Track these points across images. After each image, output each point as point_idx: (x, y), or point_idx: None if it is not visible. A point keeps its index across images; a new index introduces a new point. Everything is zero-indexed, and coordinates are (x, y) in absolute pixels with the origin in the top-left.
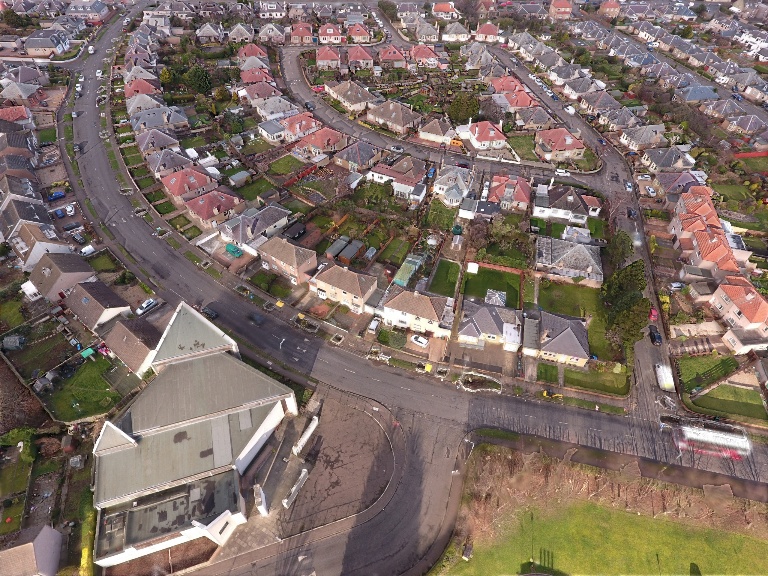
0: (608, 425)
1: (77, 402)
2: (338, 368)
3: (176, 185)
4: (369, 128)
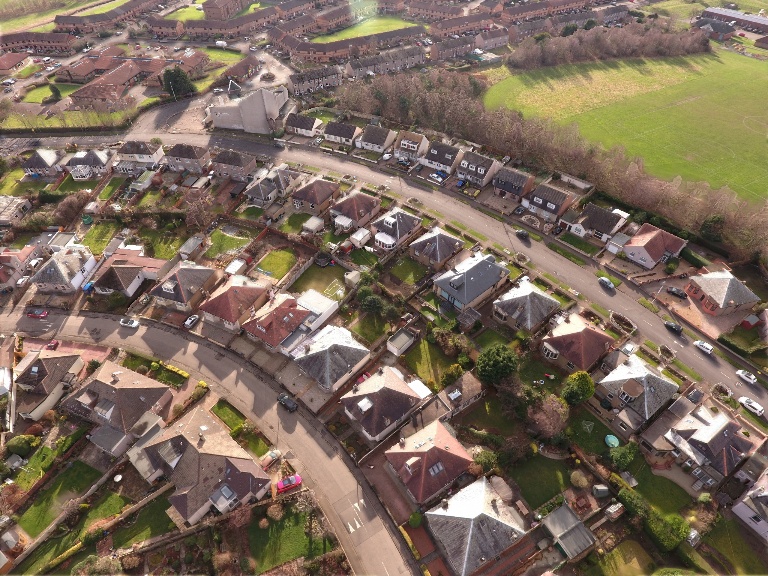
0: (48, 143)
1: (322, 116)
2: (196, 140)
3: (358, 191)
4: None
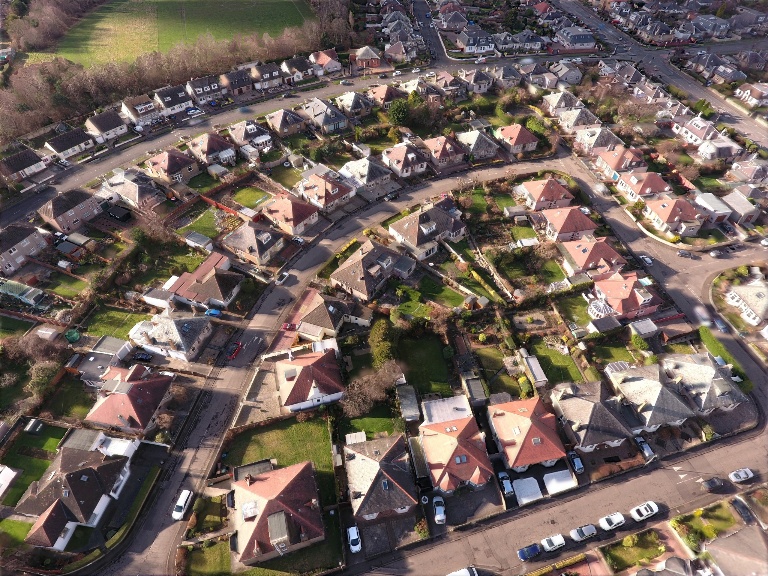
0: None
1: None
2: None
3: None
4: (342, 250)
